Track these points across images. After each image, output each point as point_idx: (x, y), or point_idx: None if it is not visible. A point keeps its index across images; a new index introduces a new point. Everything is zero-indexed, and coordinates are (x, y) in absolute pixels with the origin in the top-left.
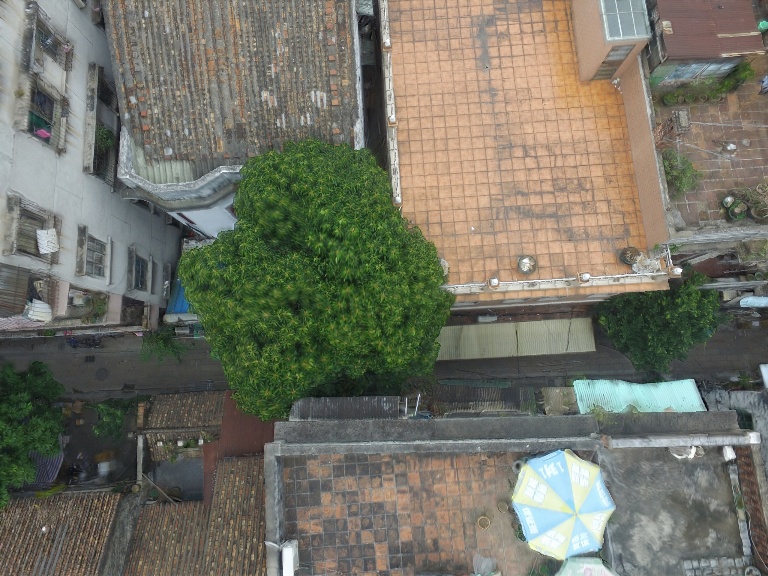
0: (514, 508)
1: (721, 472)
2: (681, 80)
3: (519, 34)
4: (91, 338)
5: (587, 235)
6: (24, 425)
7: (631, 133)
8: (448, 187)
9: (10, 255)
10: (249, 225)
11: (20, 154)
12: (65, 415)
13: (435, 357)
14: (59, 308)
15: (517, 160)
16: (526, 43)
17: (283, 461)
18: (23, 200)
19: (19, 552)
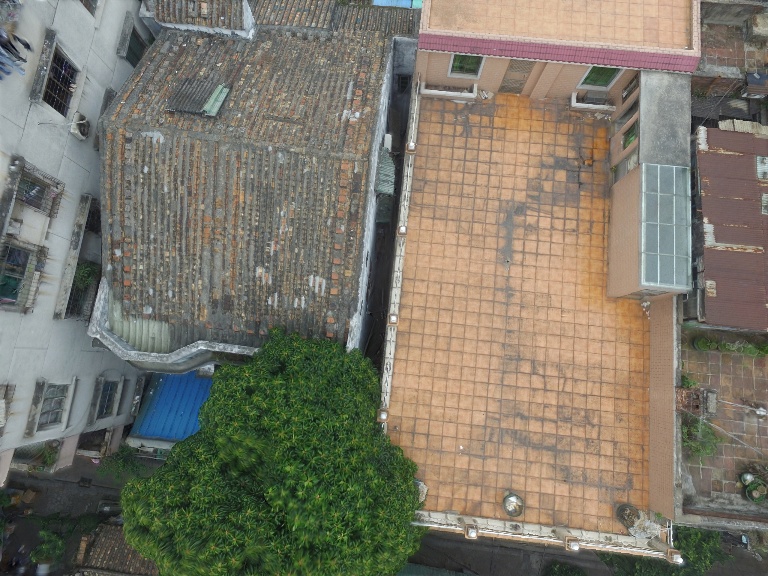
0: None
1: None
2: (717, 328)
3: (549, 229)
4: None
5: (585, 478)
6: None
7: (652, 369)
8: (443, 394)
9: None
10: (208, 456)
11: None
12: (13, 505)
13: None
14: None
15: (523, 376)
16: (555, 241)
17: None
18: None
19: None
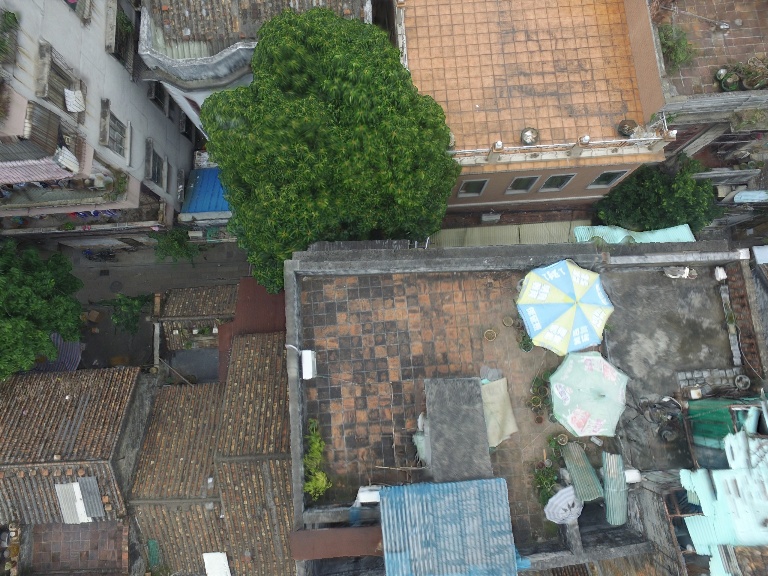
0: (519, 311)
1: (713, 294)
2: None
3: None
4: (106, 251)
5: (587, 111)
6: (47, 303)
7: (628, 17)
8: (454, 69)
9: (42, 99)
10: (267, 74)
11: (50, 10)
12: None
13: (442, 214)
14: (85, 164)
15: (519, 44)
16: None
17: (301, 285)
18: (54, 49)
19: (44, 417)
